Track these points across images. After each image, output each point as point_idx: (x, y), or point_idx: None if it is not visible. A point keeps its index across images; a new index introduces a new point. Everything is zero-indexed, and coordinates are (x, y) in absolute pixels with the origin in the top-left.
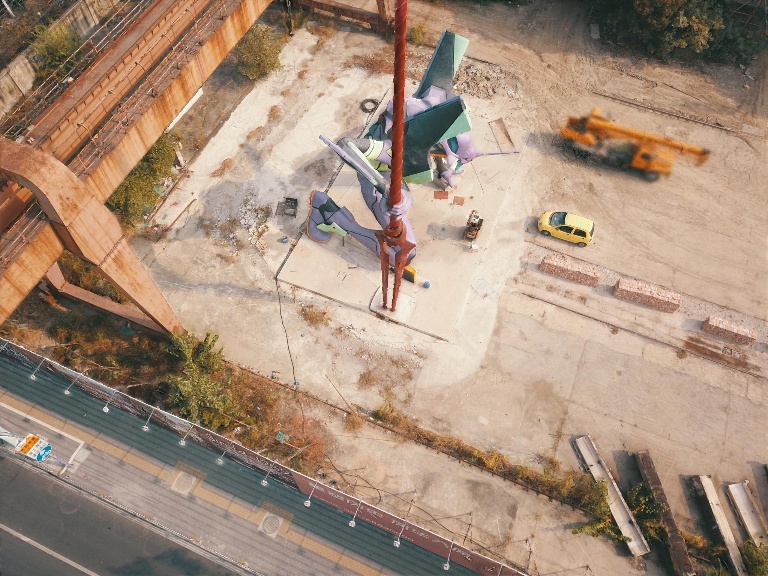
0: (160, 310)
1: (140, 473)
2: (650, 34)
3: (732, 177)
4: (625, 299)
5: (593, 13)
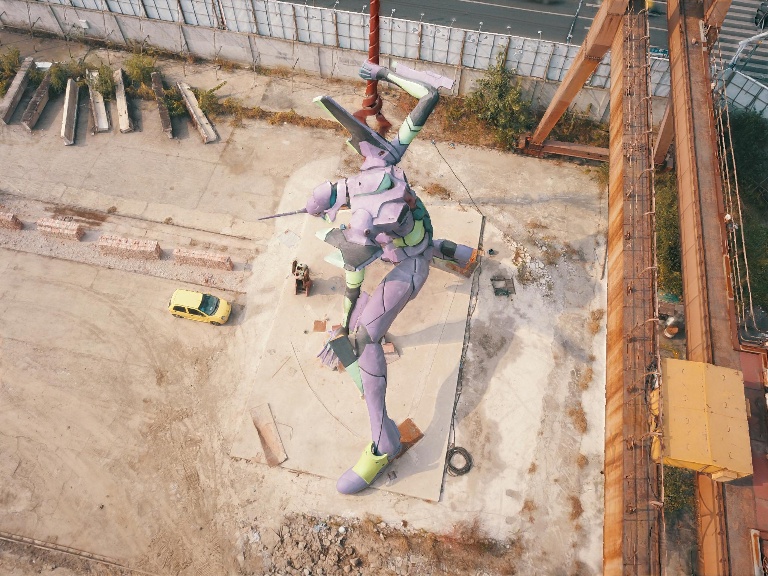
0: None
1: None
2: None
3: None
4: None
5: None
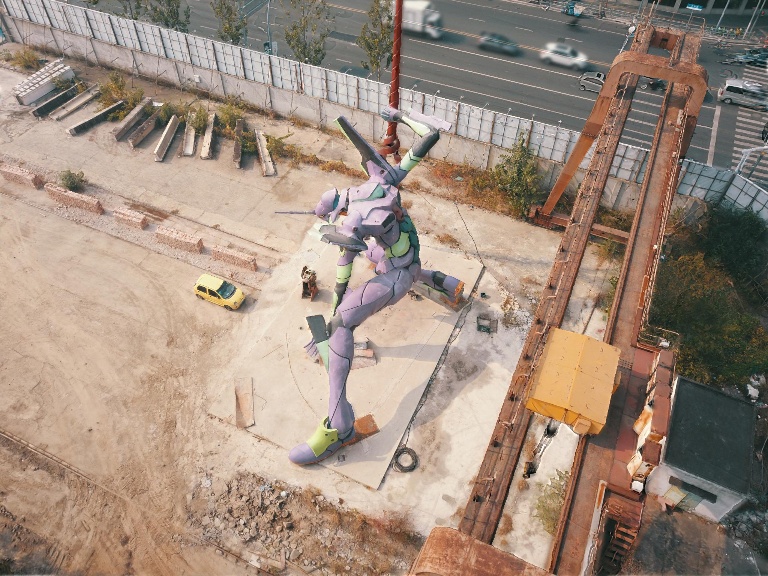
0: None
1: None
2: None
3: (8, 350)
4: None
5: None
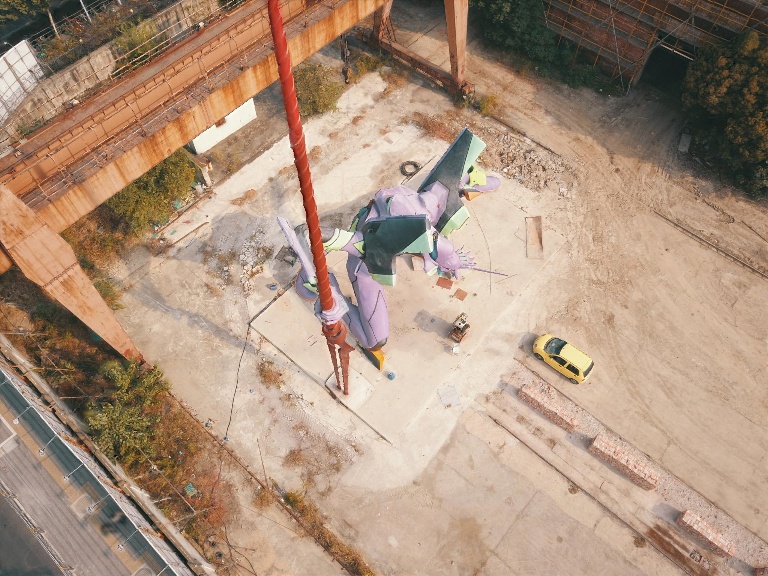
0: (112, 333)
1: (50, 481)
2: (742, 163)
3: None
4: (599, 457)
5: (690, 122)
